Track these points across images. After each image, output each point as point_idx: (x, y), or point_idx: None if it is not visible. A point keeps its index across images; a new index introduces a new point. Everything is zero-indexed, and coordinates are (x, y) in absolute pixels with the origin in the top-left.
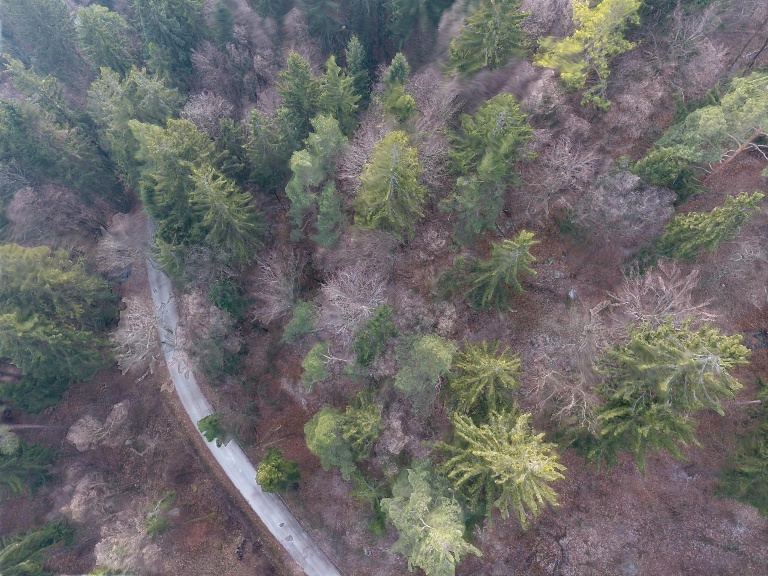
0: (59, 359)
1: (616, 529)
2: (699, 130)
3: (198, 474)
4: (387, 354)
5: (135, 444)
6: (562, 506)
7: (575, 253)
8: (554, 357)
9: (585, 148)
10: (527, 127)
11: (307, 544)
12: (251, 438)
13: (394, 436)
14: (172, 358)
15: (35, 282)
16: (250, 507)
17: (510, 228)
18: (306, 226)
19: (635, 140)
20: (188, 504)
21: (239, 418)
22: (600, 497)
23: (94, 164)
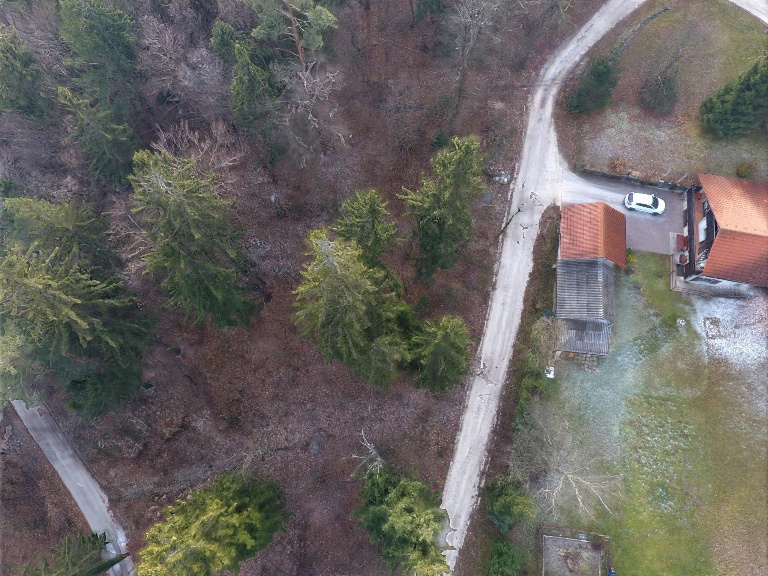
0: None
1: (309, 415)
2: (268, 11)
3: None
4: None
5: None
6: (265, 396)
7: (281, 161)
8: (267, 260)
9: (180, 32)
10: (110, 7)
11: (61, 444)
12: None
13: None
14: None
15: None
16: (15, 412)
17: (235, 142)
18: None
19: (239, 28)
20: None
21: None
22: (298, 387)
23: None
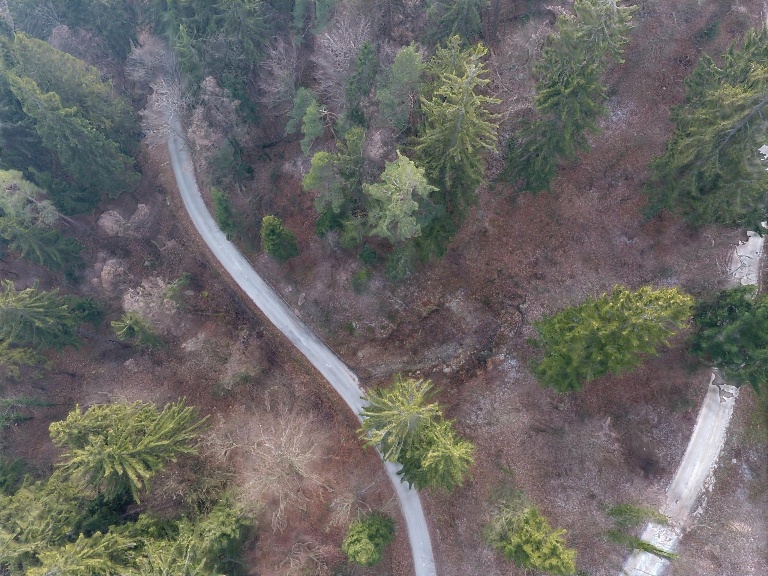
0: (92, 159)
1: (568, 291)
2: None
3: (209, 280)
4: (371, 92)
5: (153, 265)
6: (522, 275)
7: None
8: None
9: None
10: None
11: (304, 331)
12: (256, 245)
13: (375, 147)
14: (192, 129)
15: (74, 80)
16: (254, 304)
17: None
18: (306, 33)
19: None
20: (200, 309)
21: (247, 206)
22: (555, 266)
23: (120, 17)
